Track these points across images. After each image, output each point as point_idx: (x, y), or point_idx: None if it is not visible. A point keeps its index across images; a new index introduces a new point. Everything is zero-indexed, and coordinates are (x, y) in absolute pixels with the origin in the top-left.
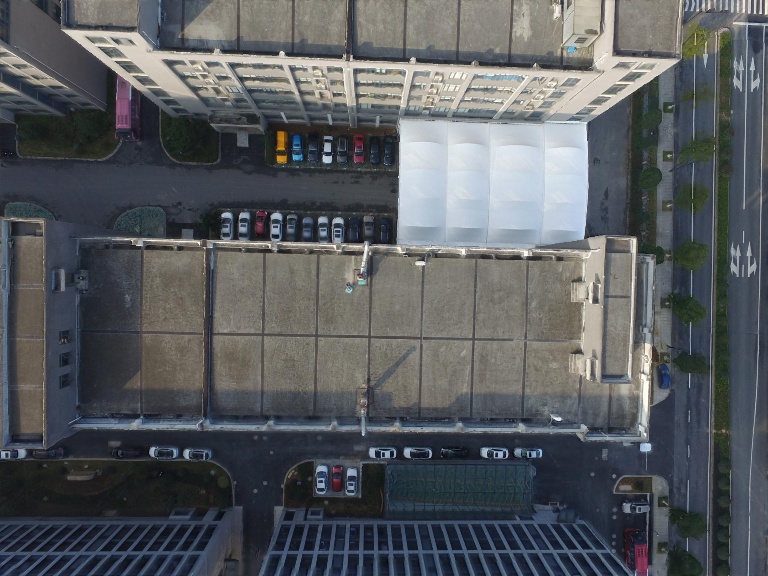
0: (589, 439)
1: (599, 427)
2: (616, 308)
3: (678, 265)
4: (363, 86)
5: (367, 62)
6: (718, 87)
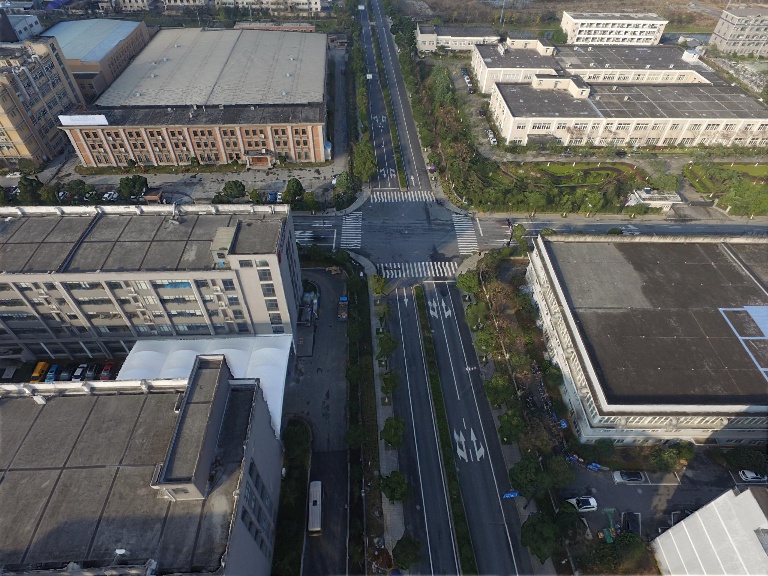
0: (150, 575)
1: (183, 571)
2: (196, 412)
3: (403, 454)
4: (85, 305)
5: (64, 274)
6: (418, 317)
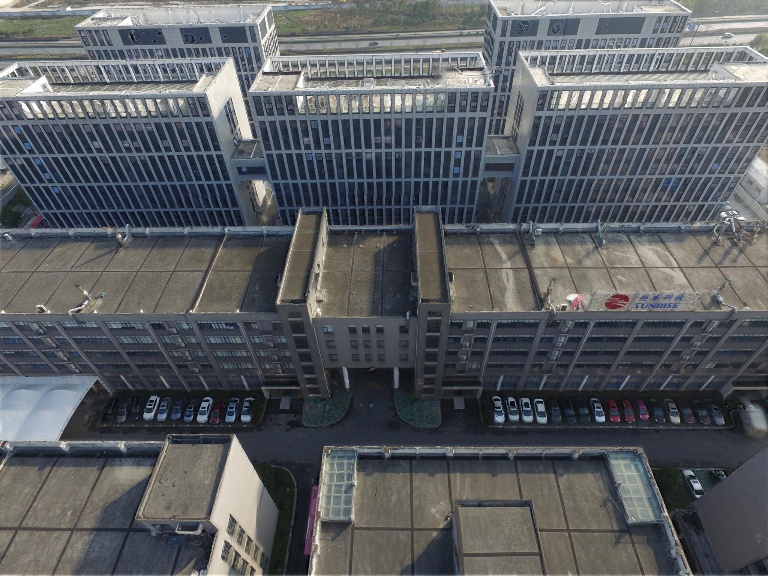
0: None
1: None
2: None
3: None
4: None
5: None
6: None
